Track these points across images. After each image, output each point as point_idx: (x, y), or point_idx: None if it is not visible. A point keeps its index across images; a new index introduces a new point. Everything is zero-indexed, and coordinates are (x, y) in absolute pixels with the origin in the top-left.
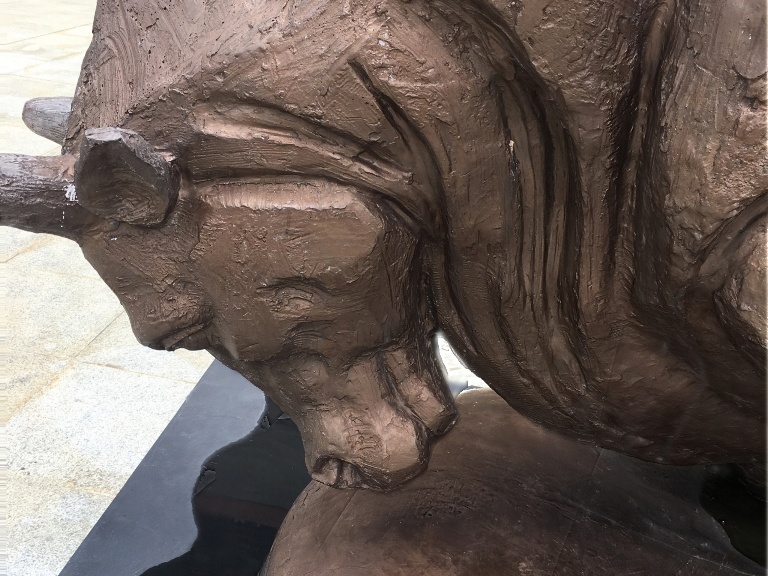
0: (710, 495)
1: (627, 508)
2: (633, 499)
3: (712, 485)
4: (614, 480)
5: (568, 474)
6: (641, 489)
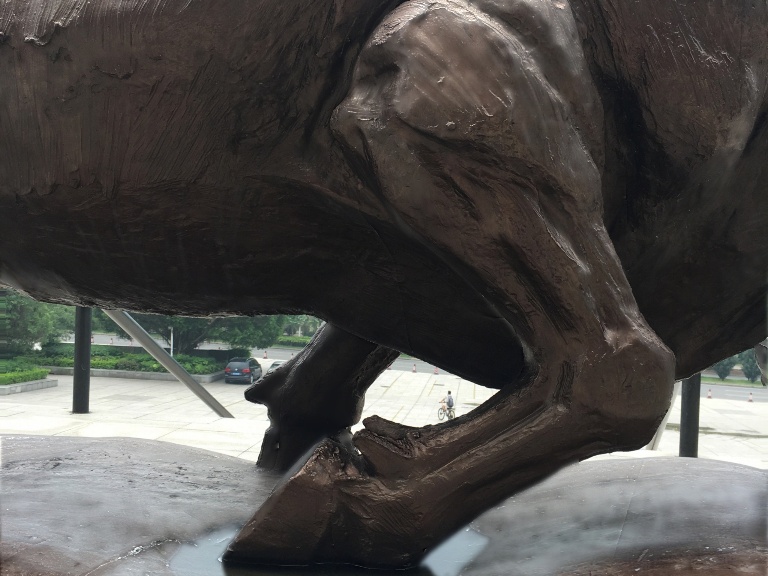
0: (474, 546)
1: (587, 495)
2: (580, 503)
3: (466, 554)
4: (605, 503)
5: (658, 491)
6: (570, 513)
